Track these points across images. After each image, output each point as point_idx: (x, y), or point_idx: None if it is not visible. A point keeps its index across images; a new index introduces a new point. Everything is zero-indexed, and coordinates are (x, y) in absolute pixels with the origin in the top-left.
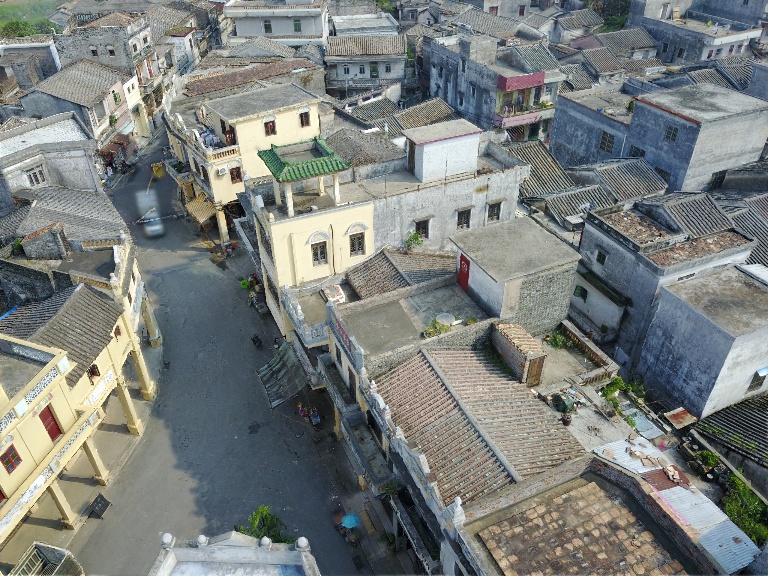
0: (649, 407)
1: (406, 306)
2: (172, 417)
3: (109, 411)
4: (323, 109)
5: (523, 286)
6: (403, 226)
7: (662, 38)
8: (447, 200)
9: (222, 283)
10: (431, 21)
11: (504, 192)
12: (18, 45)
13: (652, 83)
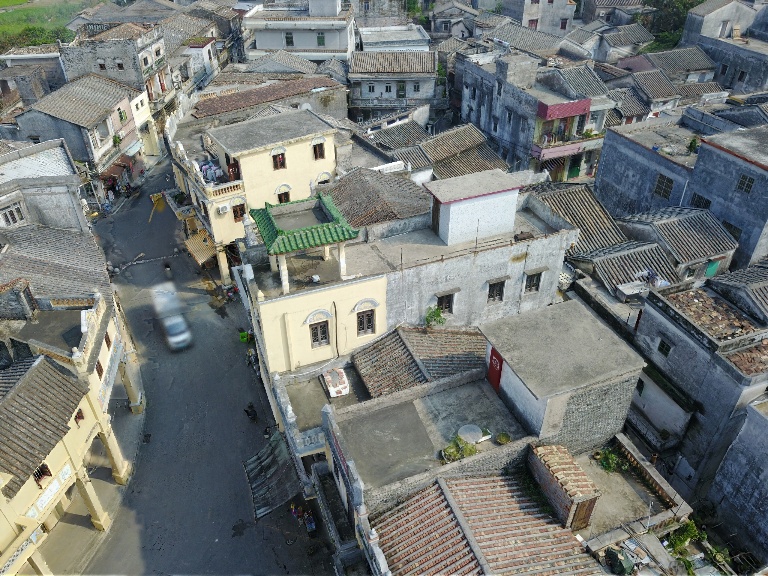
0: (723, 545)
1: (422, 409)
2: (146, 508)
3: (75, 496)
4: (340, 139)
5: (570, 401)
6: (422, 301)
7: (721, 59)
8: (477, 271)
9: (219, 334)
10: (465, 34)
11: (546, 260)
12: (26, 55)
13: (715, 115)
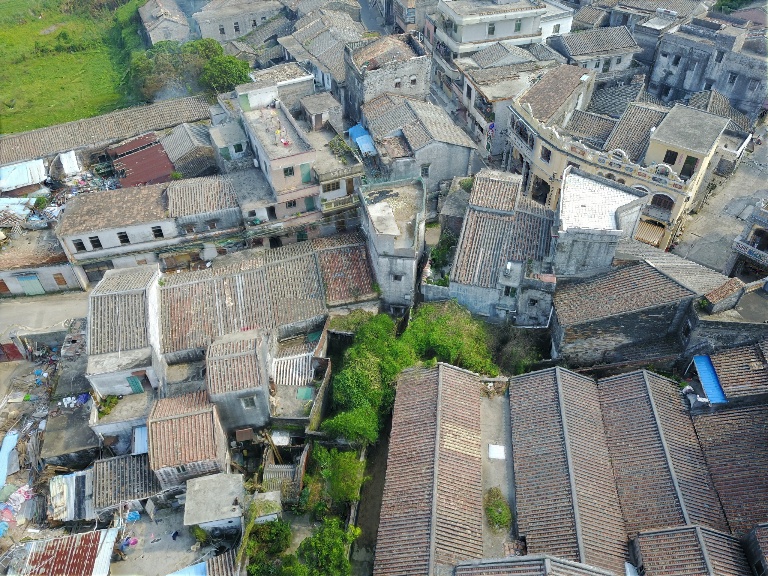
0: None
1: None
2: None
3: None
4: None
5: None
6: None
7: None
8: None
9: None
10: None
11: None
12: (285, 82)
13: None
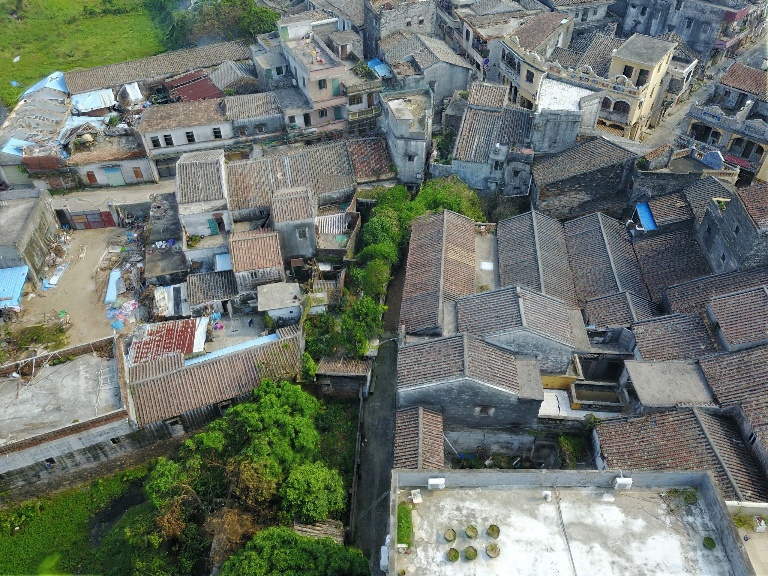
0: None
1: None
2: None
3: None
4: None
5: None
6: None
7: None
8: None
9: None
10: None
11: None
12: (314, 23)
13: None
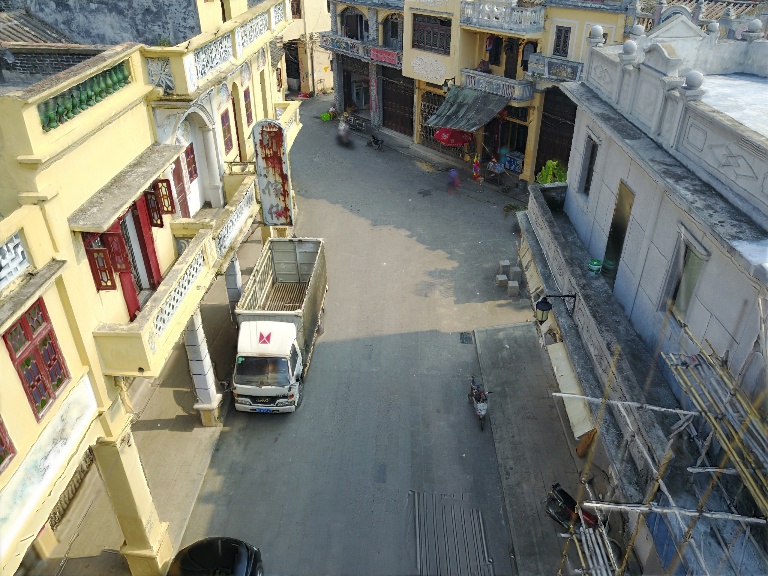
0: None
1: None
2: (322, 196)
3: None
4: None
5: None
6: None
7: None
8: None
9: None
10: None
11: None
12: None
13: None
